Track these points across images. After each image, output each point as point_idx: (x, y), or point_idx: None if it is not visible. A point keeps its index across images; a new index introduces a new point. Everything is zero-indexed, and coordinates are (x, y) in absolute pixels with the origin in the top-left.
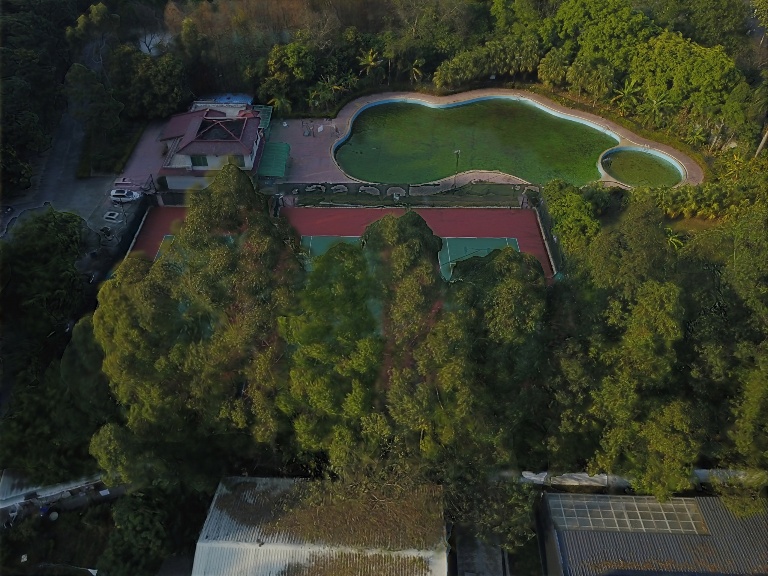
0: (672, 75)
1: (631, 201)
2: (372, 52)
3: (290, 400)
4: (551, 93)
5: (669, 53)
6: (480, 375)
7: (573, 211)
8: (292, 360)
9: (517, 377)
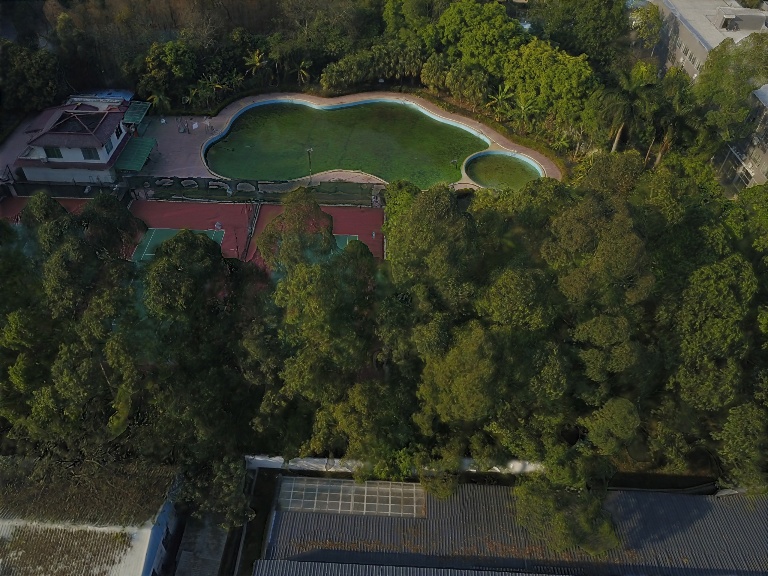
0: (540, 82)
1: None
2: (258, 53)
3: None
4: (435, 97)
5: (535, 60)
6: (179, 355)
7: (402, 209)
8: None
9: (204, 357)
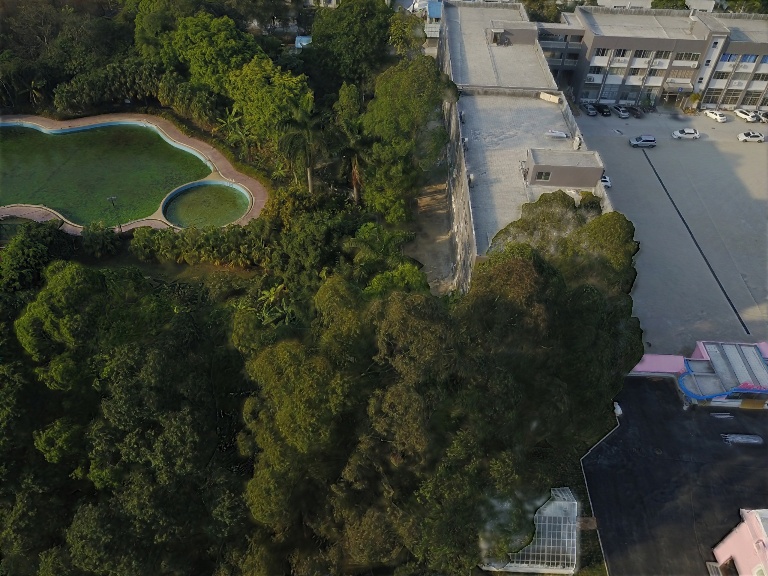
0: None
1: (131, 244)
2: None
3: None
4: (177, 120)
5: (249, 82)
6: None
7: (5, 258)
8: None
9: None
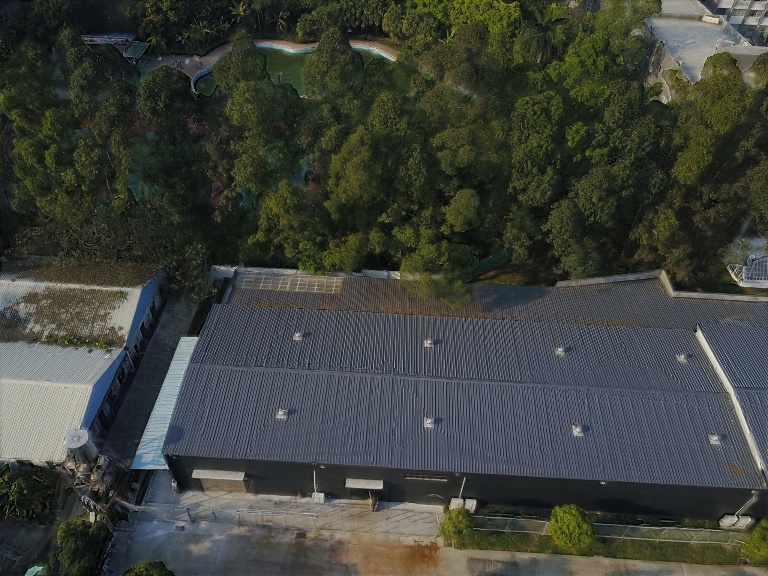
0: None
1: None
2: (243, 4)
3: (21, 167)
4: (394, 44)
5: (475, 7)
6: (162, 162)
7: None
8: (15, 132)
9: (179, 158)
